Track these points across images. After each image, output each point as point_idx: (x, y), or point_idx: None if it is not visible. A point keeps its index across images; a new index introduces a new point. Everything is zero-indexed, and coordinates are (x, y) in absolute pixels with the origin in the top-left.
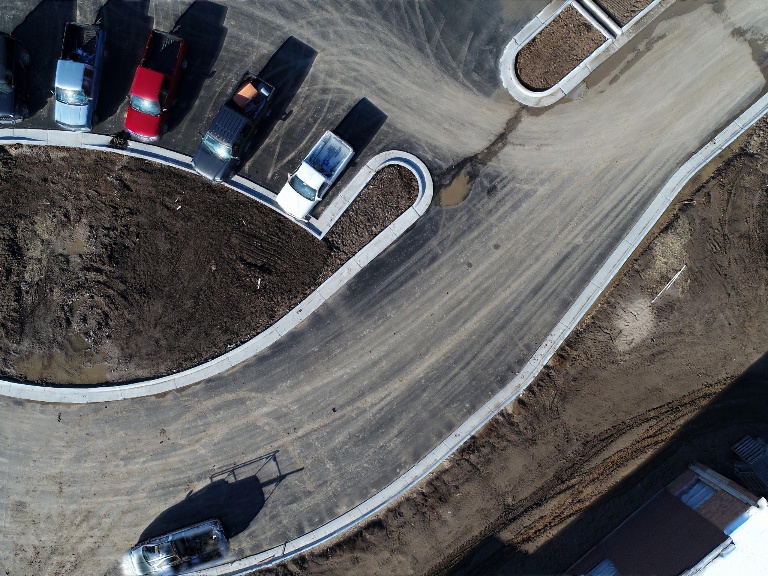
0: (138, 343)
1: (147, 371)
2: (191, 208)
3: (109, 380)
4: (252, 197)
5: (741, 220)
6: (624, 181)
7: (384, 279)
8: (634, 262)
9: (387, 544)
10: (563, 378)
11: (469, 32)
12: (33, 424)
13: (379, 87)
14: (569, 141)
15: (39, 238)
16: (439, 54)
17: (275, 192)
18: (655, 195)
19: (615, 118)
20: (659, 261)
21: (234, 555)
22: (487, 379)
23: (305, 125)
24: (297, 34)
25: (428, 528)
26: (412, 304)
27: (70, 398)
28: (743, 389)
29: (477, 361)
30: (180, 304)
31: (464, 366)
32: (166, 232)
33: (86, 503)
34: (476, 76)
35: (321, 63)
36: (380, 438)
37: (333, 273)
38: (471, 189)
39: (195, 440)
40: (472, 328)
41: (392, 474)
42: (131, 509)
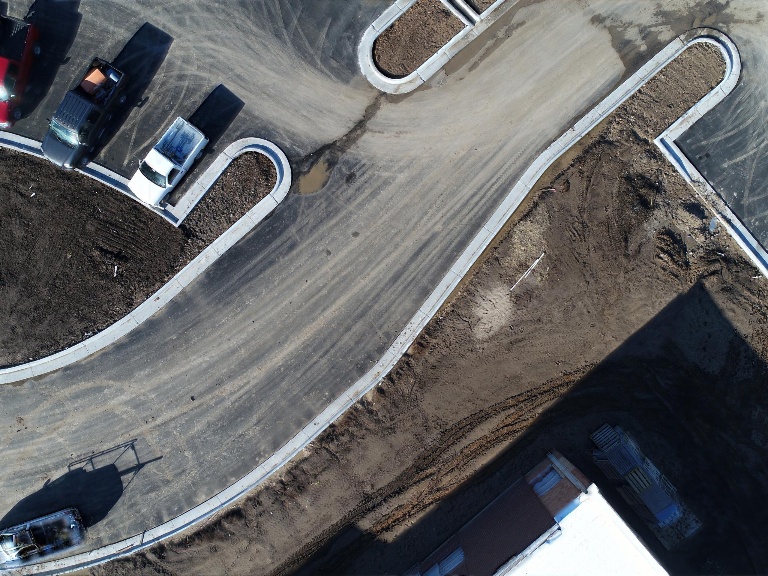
0: None
1: (4, 359)
2: (45, 195)
3: None
4: (107, 184)
5: (600, 208)
6: (483, 169)
7: (242, 267)
8: (494, 250)
9: (245, 533)
10: (422, 366)
11: (327, 18)
12: None
13: (236, 74)
14: (428, 128)
15: None
16: (296, 41)
17: None
18: (515, 183)
19: (474, 105)
20: (518, 249)
21: (92, 544)
22: (346, 367)
23: (161, 112)
24: (153, 20)
25: (287, 517)
26: (271, 292)
27: None
28: (602, 377)
29: (336, 349)
30: (36, 292)
31: (323, 354)
32: (20, 219)
33: None
34: (334, 63)
35: (177, 49)
36: (239, 426)
37: (191, 261)
38: (330, 176)
39: (53, 428)
40: (331, 316)
41: (251, 463)
42: None
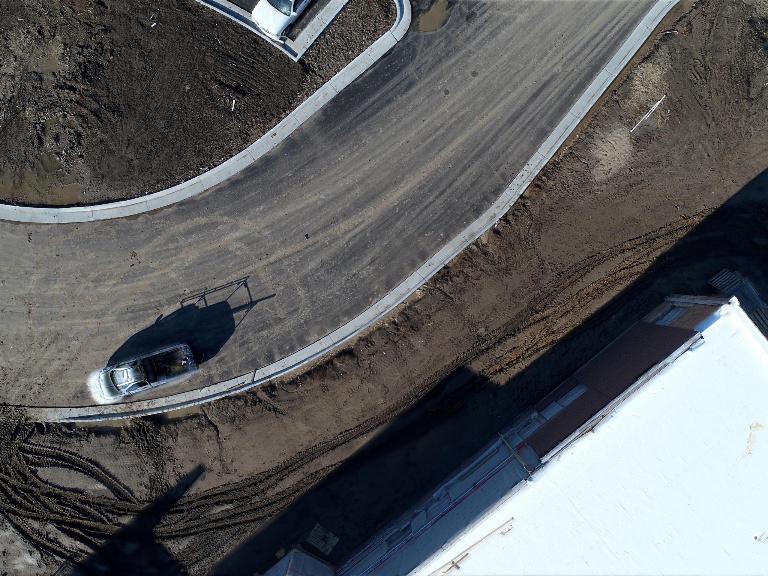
0: (110, 163)
1: (119, 192)
2: (166, 25)
3: (80, 201)
4: (228, 16)
5: (723, 51)
6: (605, 10)
7: (360, 104)
8: (613, 92)
9: (358, 372)
10: (539, 208)
11: None
12: (3, 244)
13: None
14: None
15: (12, 54)
16: None
17: (251, 12)
18: (636, 25)
19: None
20: (639, 90)
21: (203, 381)
22: (462, 208)
23: None
24: None
25: (399, 357)
26: (388, 131)
27: (41, 218)
28: (721, 222)
29: (452, 190)
30: (153, 124)
31: (439, 195)
32: (140, 50)
33: (55, 325)
34: None
35: None
36: (353, 266)
37: (308, 97)
38: (450, 15)
39: (166, 264)
40: (448, 156)
41: (364, 303)
42: (100, 332)
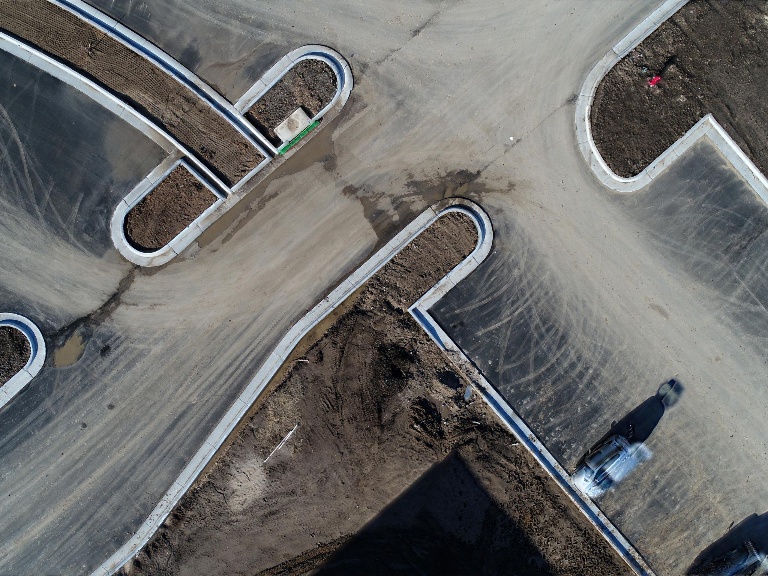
0: None
1: None
2: None
3: None
4: None
5: (354, 378)
6: (238, 340)
7: None
8: (250, 420)
9: None
10: (177, 539)
11: (79, 194)
12: None
13: None
14: (182, 300)
15: None
16: (49, 216)
17: None
18: (269, 353)
19: (228, 277)
20: (271, 421)
21: None
22: (103, 540)
23: None
24: None
25: None
26: (27, 465)
27: None
28: (357, 548)
29: (93, 522)
30: None
31: (80, 527)
32: None
33: None
34: (87, 237)
35: None
36: None
37: None
38: (85, 349)
39: None
40: (87, 489)
41: None
42: None
